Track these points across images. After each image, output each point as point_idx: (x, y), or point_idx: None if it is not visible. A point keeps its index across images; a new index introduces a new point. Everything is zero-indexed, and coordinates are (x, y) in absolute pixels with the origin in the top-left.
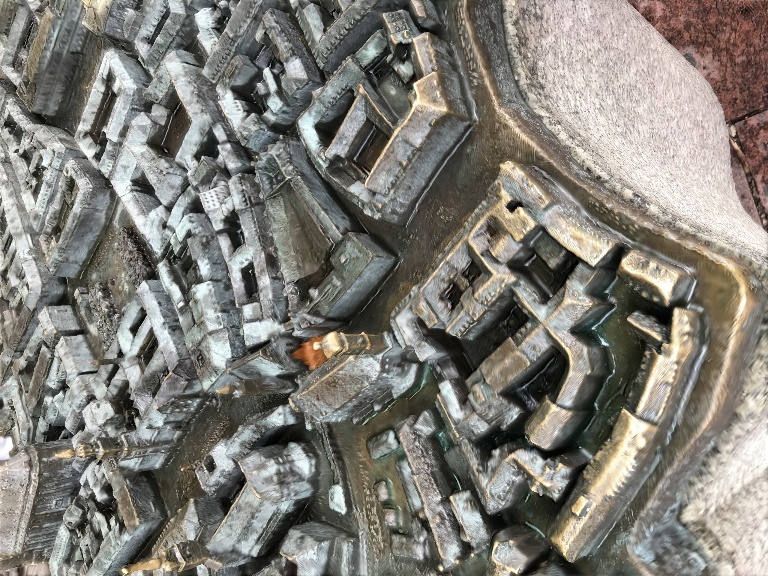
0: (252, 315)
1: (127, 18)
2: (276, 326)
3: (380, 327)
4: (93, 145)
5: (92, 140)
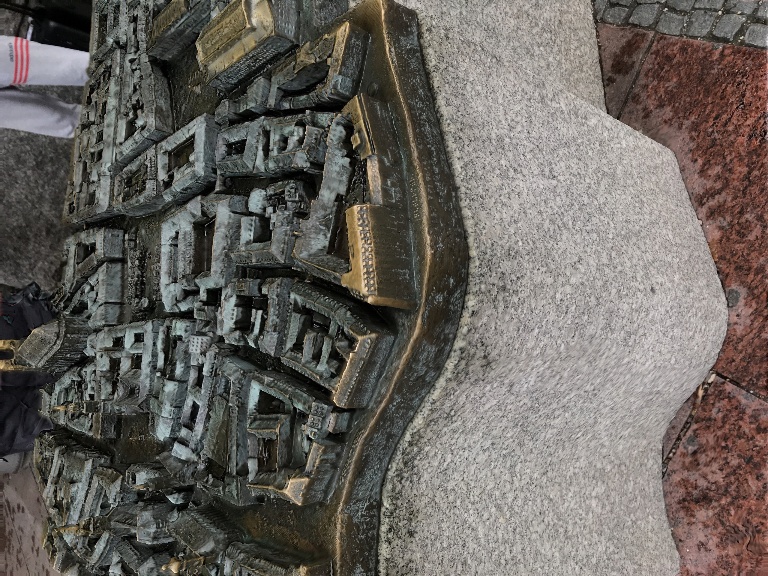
0: (185, 436)
1: (220, 110)
2: (194, 455)
3: (239, 517)
4: (166, 168)
5: (168, 161)
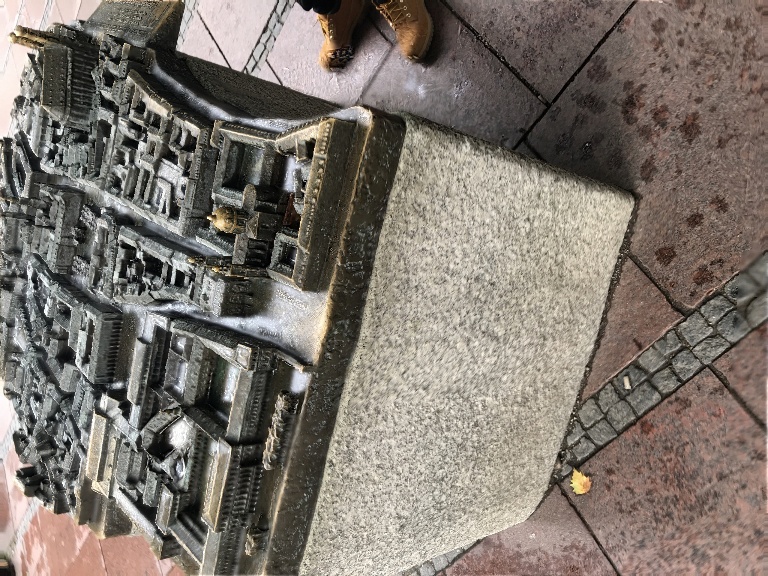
0: None
1: (87, 404)
2: None
3: None
4: None
5: None
